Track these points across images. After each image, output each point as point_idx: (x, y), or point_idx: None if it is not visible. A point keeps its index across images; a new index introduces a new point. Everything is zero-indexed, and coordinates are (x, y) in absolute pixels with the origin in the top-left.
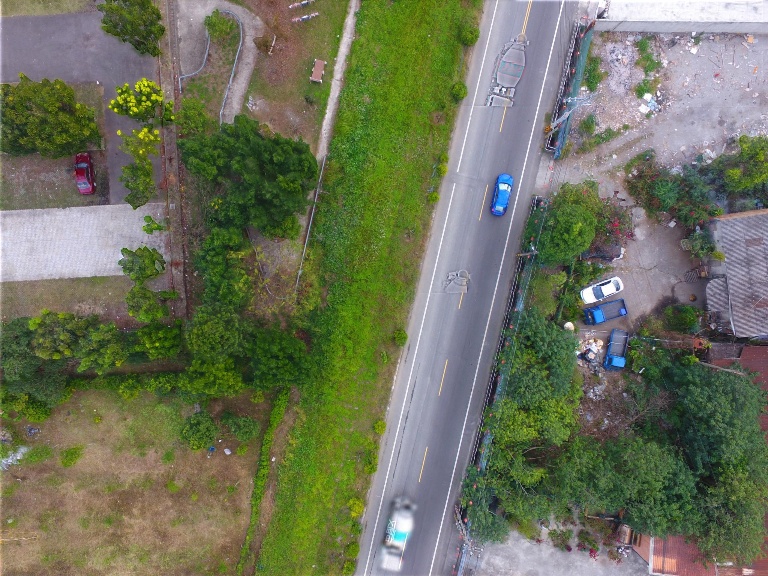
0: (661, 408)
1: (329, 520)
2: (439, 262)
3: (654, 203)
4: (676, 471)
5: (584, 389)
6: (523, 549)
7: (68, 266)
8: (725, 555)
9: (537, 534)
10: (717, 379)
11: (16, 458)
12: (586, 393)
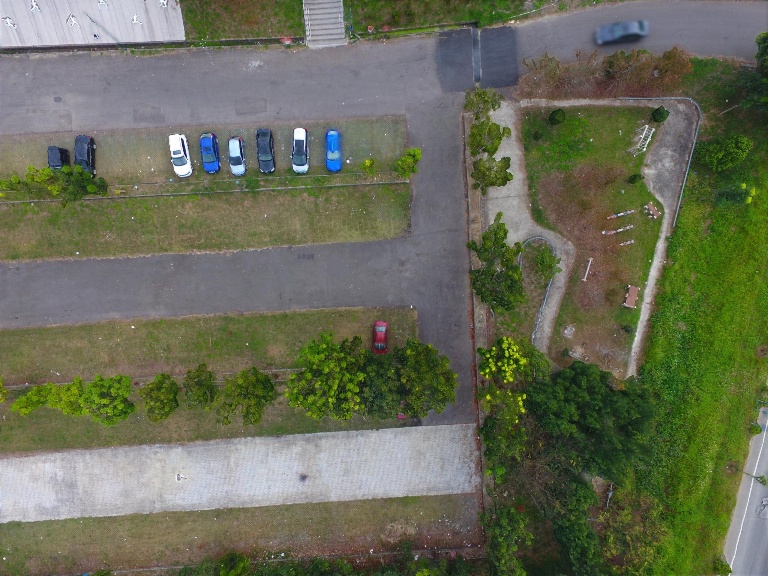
0: None
1: None
2: (754, 488)
3: None
4: None
5: None
6: None
7: (381, 486)
8: None
9: None
10: None
11: None
12: None
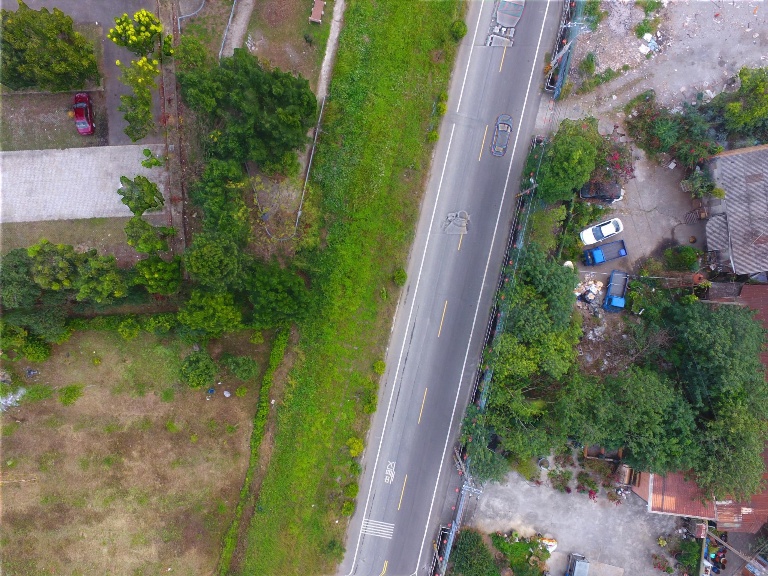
0: (661, 345)
1: (328, 460)
2: (439, 203)
3: (654, 143)
4: (675, 405)
5: (584, 330)
6: (522, 491)
7: (67, 207)
8: (724, 491)
9: (536, 476)
10: (717, 314)
11: (15, 400)
12: (586, 334)
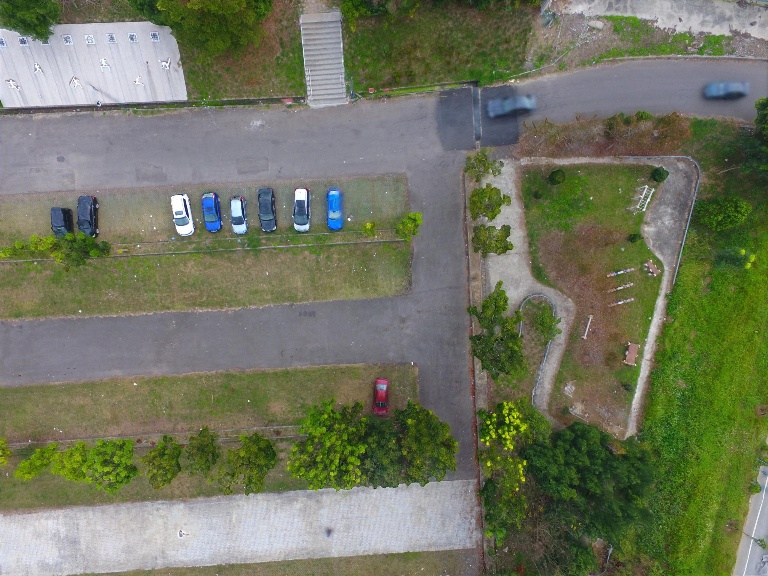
0: None
1: None
2: (754, 545)
3: None
4: None
5: None
6: None
7: (382, 542)
8: None
9: None
10: None
11: None
12: None
